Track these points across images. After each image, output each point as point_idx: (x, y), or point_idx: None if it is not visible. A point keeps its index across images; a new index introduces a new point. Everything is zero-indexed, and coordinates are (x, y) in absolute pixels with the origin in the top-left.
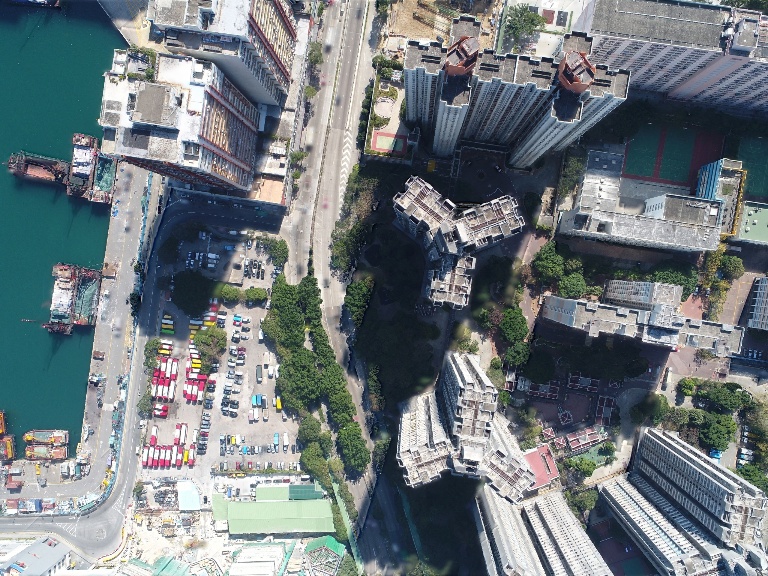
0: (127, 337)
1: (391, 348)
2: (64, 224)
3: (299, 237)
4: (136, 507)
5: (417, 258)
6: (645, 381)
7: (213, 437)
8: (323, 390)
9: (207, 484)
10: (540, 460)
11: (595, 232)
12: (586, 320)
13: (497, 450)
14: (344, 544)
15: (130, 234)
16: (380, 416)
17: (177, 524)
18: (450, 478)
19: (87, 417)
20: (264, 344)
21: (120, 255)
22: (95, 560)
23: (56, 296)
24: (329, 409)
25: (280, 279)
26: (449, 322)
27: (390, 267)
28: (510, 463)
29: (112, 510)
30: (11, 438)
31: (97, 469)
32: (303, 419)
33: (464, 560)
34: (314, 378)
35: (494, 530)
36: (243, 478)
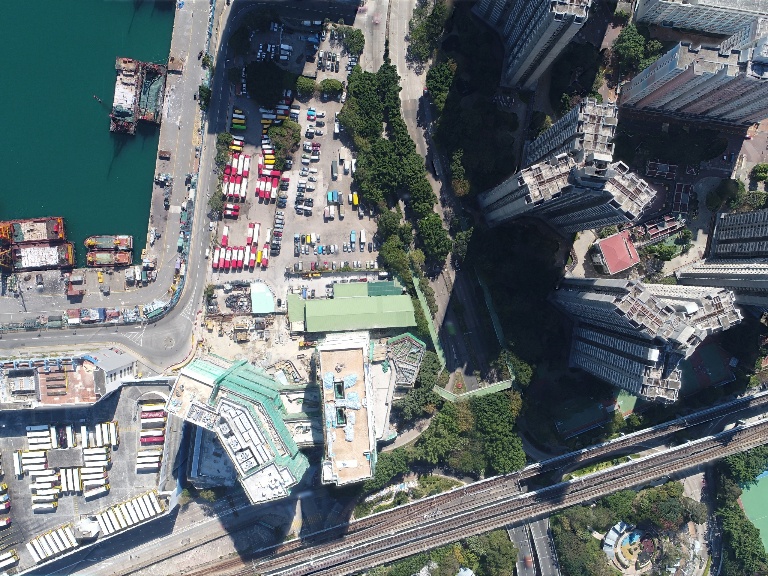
0: (195, 135)
1: (475, 131)
2: (125, 19)
3: (374, 28)
4: (206, 313)
5: (495, 49)
6: (720, 169)
7: (287, 237)
8: (405, 177)
9: (281, 286)
10: (623, 243)
11: (681, 2)
12: (689, 61)
13: (619, 163)
14: (423, 342)
15: (197, 27)
16: (459, 211)
17: (250, 328)
18: (533, 265)
19: (153, 220)
20: (339, 139)
21: (186, 49)
22: (163, 370)
23: (119, 91)
24: (407, 205)
25: (357, 69)
26: (528, 112)
27: (471, 52)
28: (632, 177)
29: (181, 317)
30: (71, 244)
31: (164, 275)
32: (381, 213)
33: (545, 351)
34: (396, 164)
35: (596, 282)
36: (318, 279)
